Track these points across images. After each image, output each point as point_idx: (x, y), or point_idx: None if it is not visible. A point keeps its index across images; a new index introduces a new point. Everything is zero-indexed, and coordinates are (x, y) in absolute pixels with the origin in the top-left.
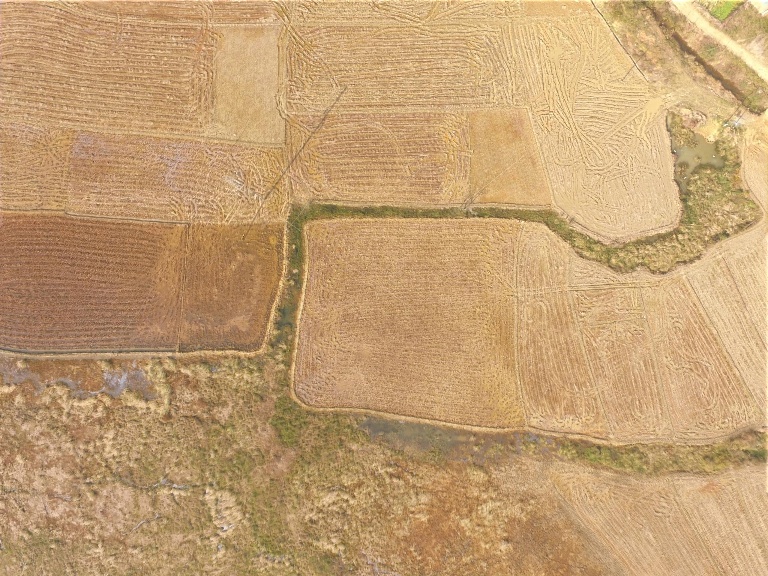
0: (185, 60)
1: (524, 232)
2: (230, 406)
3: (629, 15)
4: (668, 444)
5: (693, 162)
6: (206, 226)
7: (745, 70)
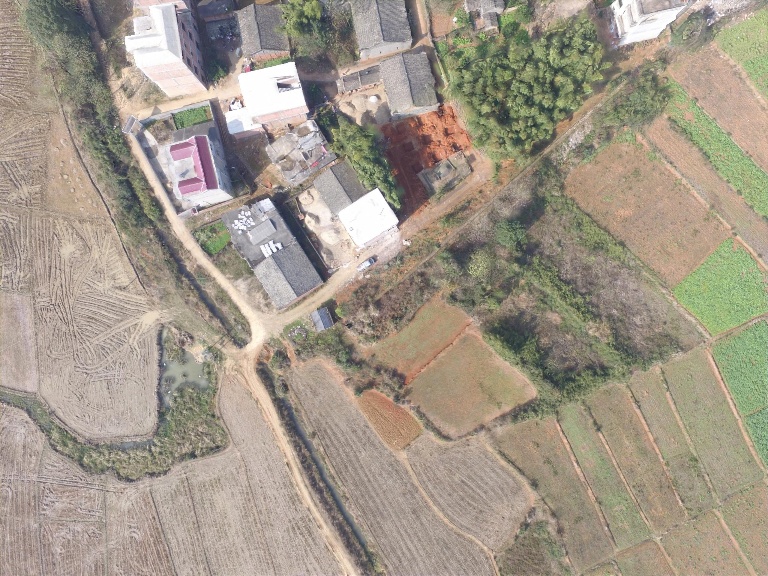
0: None
1: (5, 415)
2: None
3: (133, 231)
4: None
5: (179, 378)
6: None
7: (229, 304)
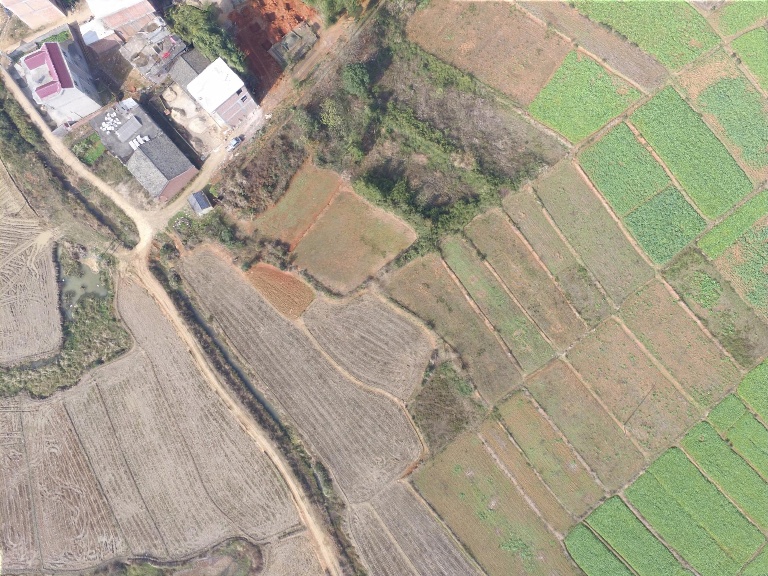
0: None
1: None
2: None
3: (16, 158)
4: (38, 575)
5: (78, 291)
6: None
7: (114, 209)
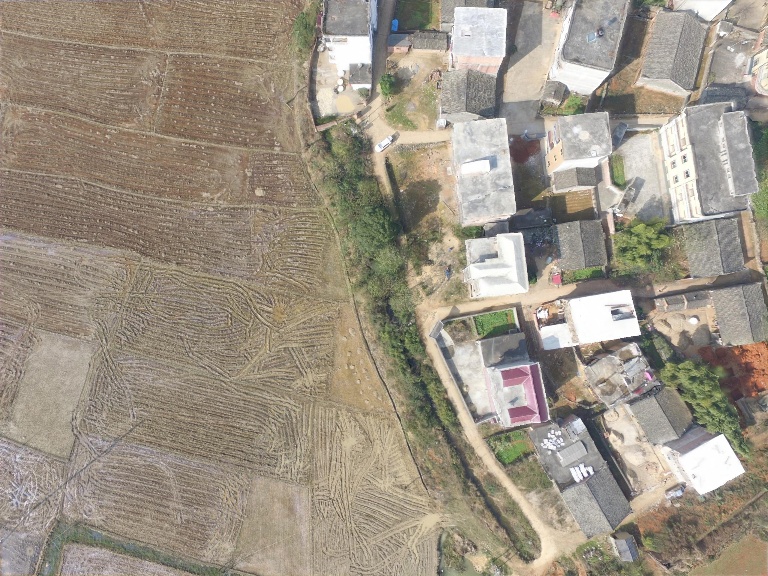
0: None
1: None
2: None
3: (422, 431)
4: None
5: None
6: None
7: (520, 517)
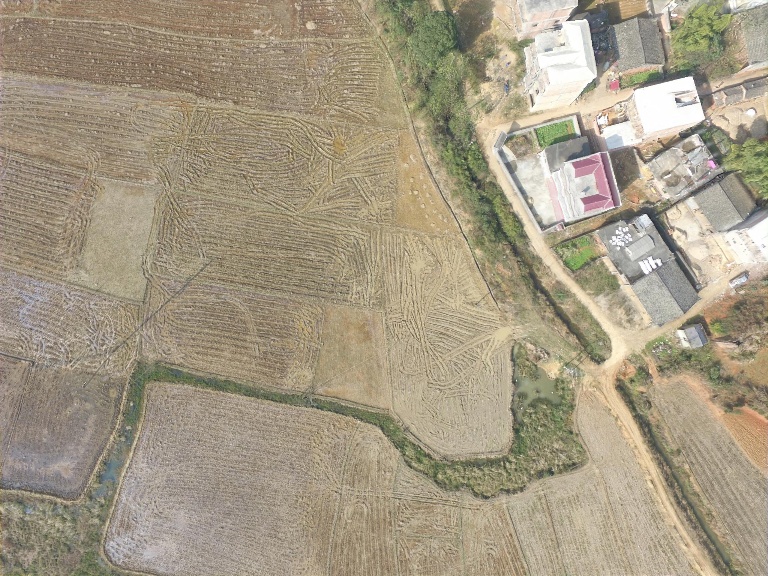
0: (63, 205)
1: (358, 432)
2: (36, 551)
3: (490, 246)
4: None
5: (532, 394)
6: (50, 367)
7: (590, 320)
